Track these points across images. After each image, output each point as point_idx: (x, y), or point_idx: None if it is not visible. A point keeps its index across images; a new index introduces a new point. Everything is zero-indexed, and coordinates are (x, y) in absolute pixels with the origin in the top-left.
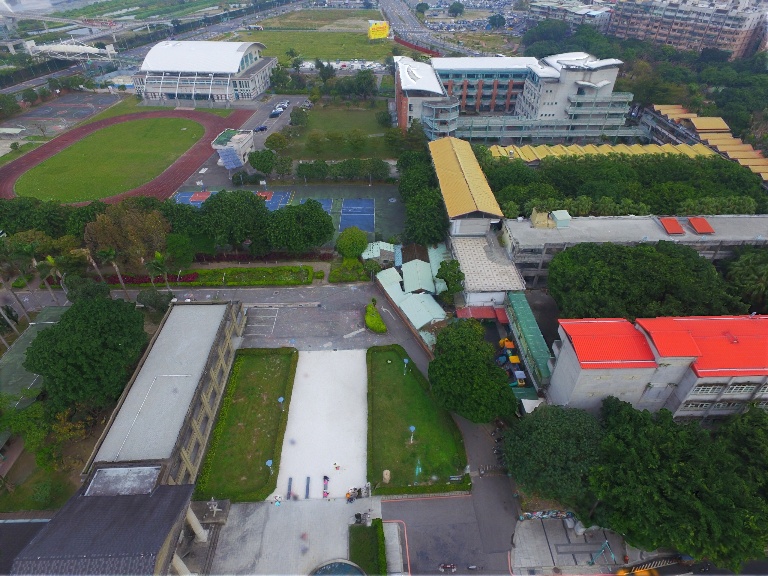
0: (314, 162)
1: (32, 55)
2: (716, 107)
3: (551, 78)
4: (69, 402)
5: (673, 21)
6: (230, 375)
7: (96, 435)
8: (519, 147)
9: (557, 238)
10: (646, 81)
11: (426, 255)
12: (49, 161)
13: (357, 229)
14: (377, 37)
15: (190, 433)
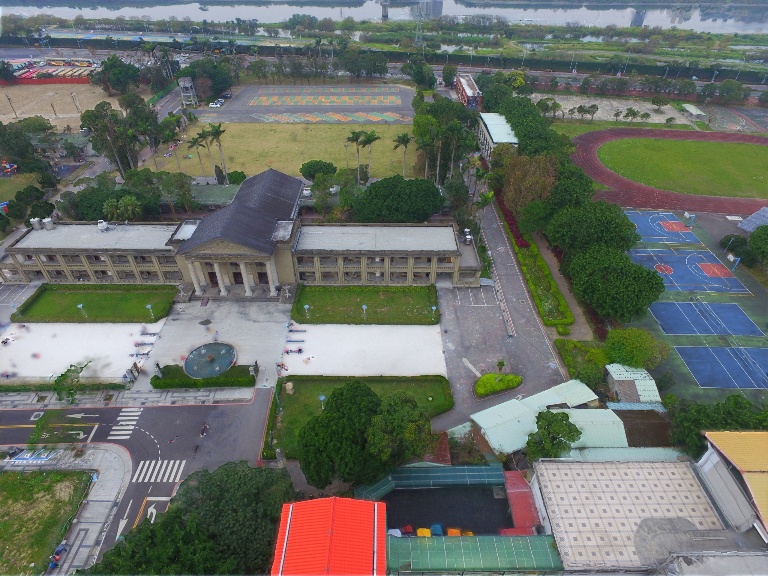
0: None
1: None
2: None
3: None
4: None
5: None
6: None
7: None
8: None
9: None
10: None
11: (650, 442)
12: (667, 141)
13: (648, 340)
14: None
15: None
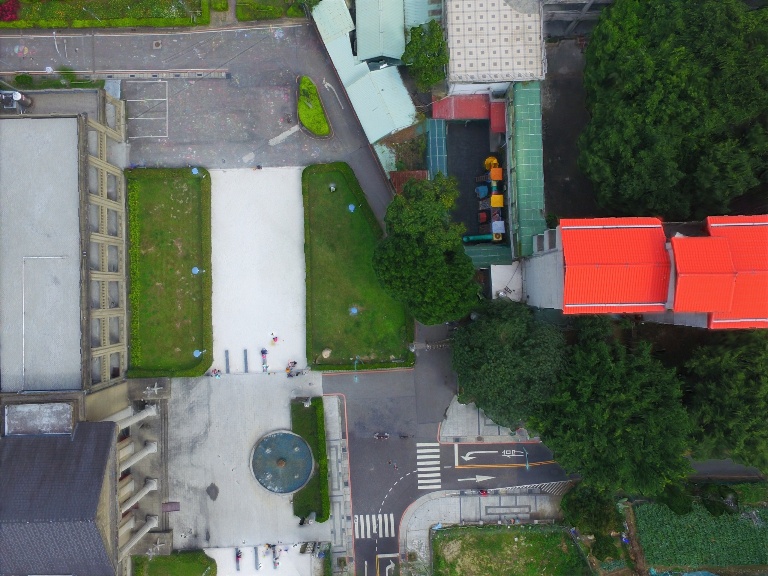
0: None
1: None
2: None
3: None
4: None
5: None
6: (127, 211)
7: None
8: None
9: None
10: None
11: None
12: None
13: None
14: None
15: (98, 321)
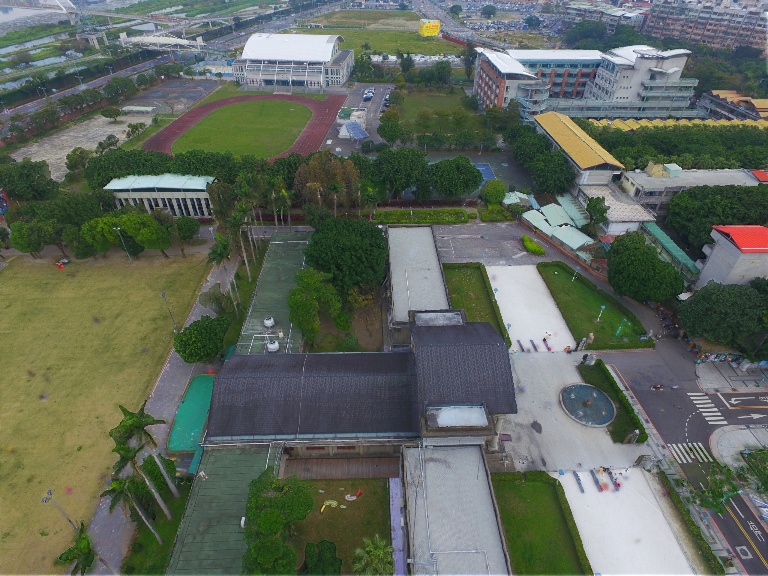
0: (433, 133)
1: (124, 46)
2: (764, 93)
3: (627, 65)
4: (355, 282)
5: (707, 22)
6: None
7: (366, 311)
8: (611, 121)
9: (673, 184)
10: (702, 70)
11: (557, 201)
12: (189, 133)
13: None
14: (429, 35)
15: None
